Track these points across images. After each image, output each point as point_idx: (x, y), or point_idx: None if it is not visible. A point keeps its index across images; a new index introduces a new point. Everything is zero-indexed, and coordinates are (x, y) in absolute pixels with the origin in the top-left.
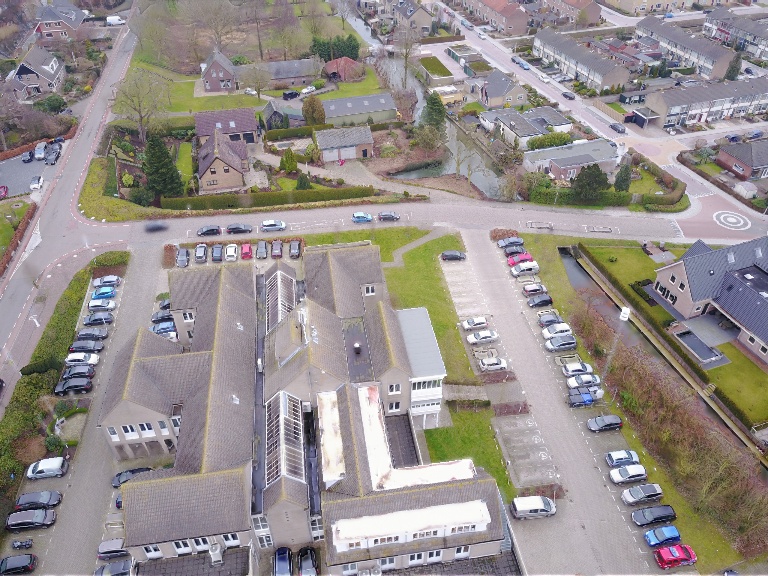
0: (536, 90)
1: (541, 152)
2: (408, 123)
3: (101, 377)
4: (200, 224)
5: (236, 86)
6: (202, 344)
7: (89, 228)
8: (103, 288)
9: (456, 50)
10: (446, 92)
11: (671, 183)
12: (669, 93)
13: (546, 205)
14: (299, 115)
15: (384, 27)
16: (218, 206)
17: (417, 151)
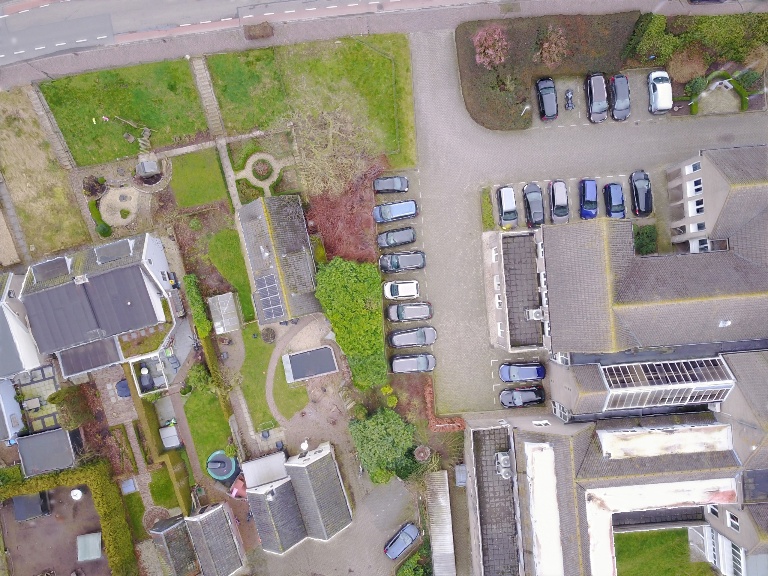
0: None
1: None
2: None
3: None
4: None
5: None
6: None
7: None
8: None
9: None
10: None
11: None
12: None
13: None
14: None
15: None
16: None
17: None
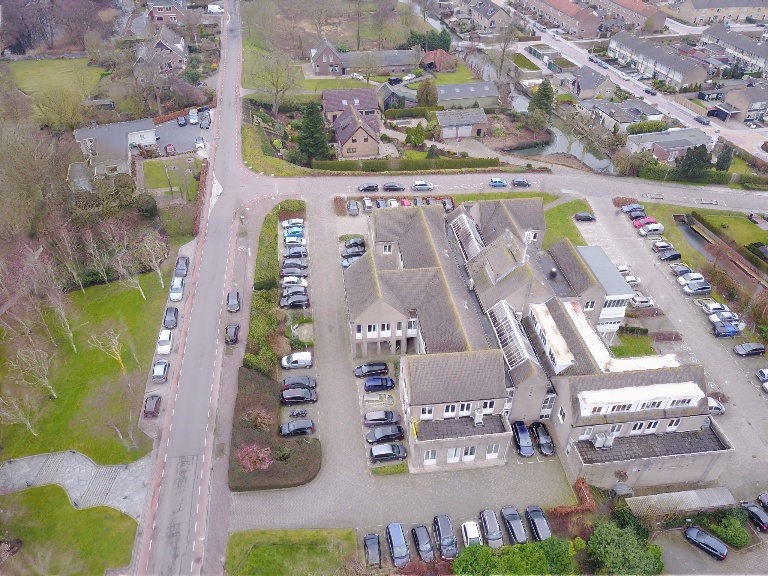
0: (619, 86)
1: (643, 136)
2: (513, 108)
3: (313, 297)
4: (358, 182)
5: (342, 71)
6: (421, 265)
7: (262, 181)
8: (294, 228)
9: (538, 48)
10: None
11: (762, 167)
12: (750, 90)
13: (655, 180)
14: (411, 98)
15: (464, 26)
16: (362, 170)
17: (524, 133)
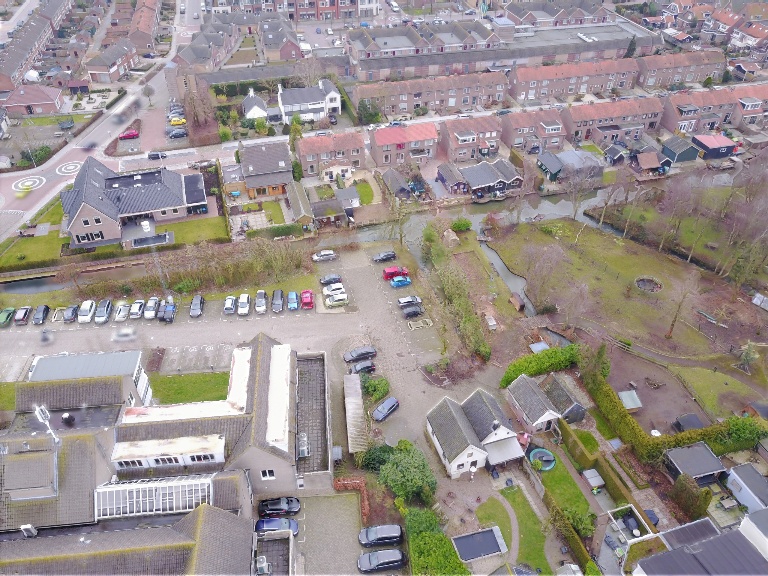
0: None
1: None
2: None
3: None
4: None
5: None
6: None
7: None
8: None
9: None
10: None
11: None
12: None
13: None
14: None
15: None
16: None
17: None
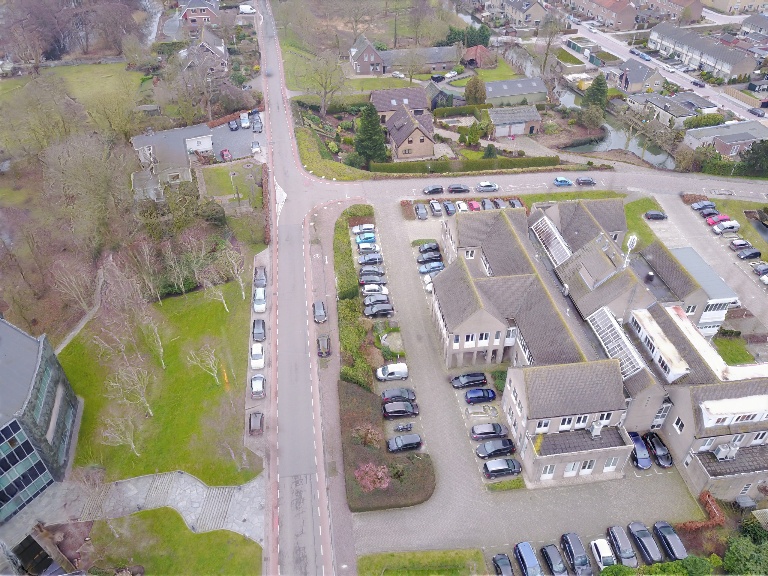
0: (666, 78)
1: (702, 130)
2: (563, 104)
3: (396, 305)
4: (421, 184)
5: (383, 70)
6: (513, 271)
7: (325, 185)
8: (366, 234)
9: (577, 42)
10: (586, 78)
11: None
12: None
13: (720, 176)
14: (458, 96)
15: (498, 20)
16: (421, 171)
17: (577, 129)
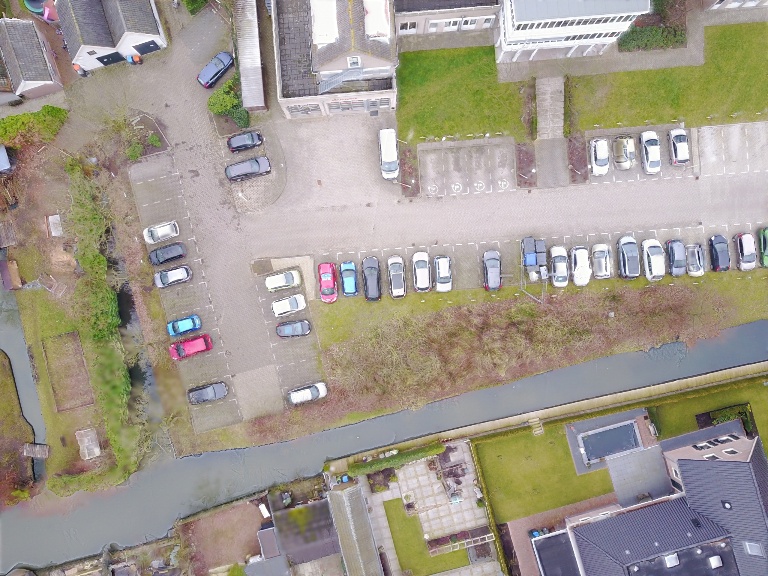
0: None
1: None
2: None
3: None
4: None
5: None
6: None
7: None
8: None
9: None
10: None
11: None
12: None
13: None
14: None
15: None
16: None
17: None
